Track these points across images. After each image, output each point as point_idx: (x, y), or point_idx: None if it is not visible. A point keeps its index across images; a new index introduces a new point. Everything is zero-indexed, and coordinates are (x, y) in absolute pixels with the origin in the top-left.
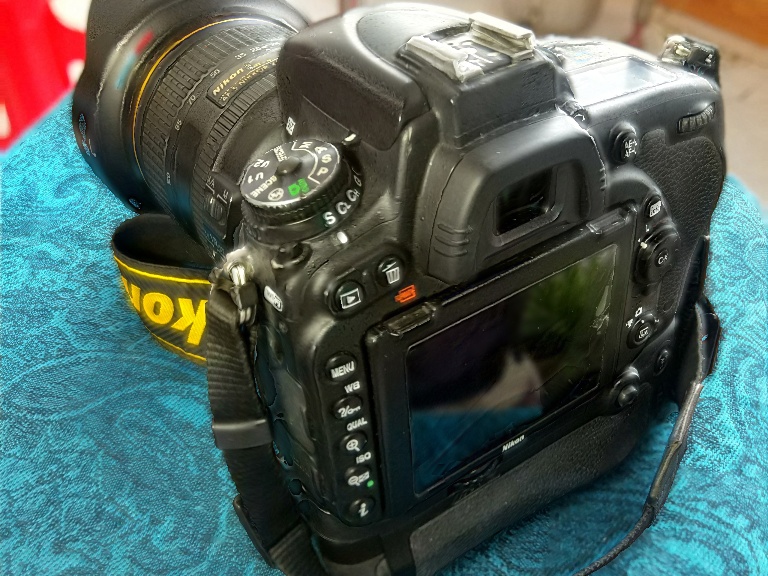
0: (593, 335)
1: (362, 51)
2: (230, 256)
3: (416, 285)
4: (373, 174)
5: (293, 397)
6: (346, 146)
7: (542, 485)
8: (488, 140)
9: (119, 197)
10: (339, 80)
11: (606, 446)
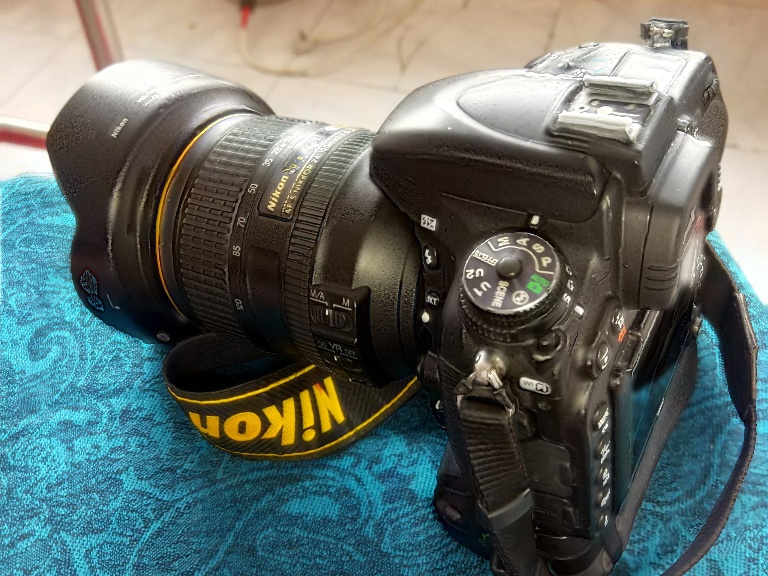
0: (689, 293)
1: (505, 139)
2: (479, 365)
3: (624, 321)
4: (572, 245)
5: (549, 459)
6: (537, 229)
7: (666, 428)
8: (660, 182)
9: (146, 337)
10: (495, 172)
11: (686, 373)
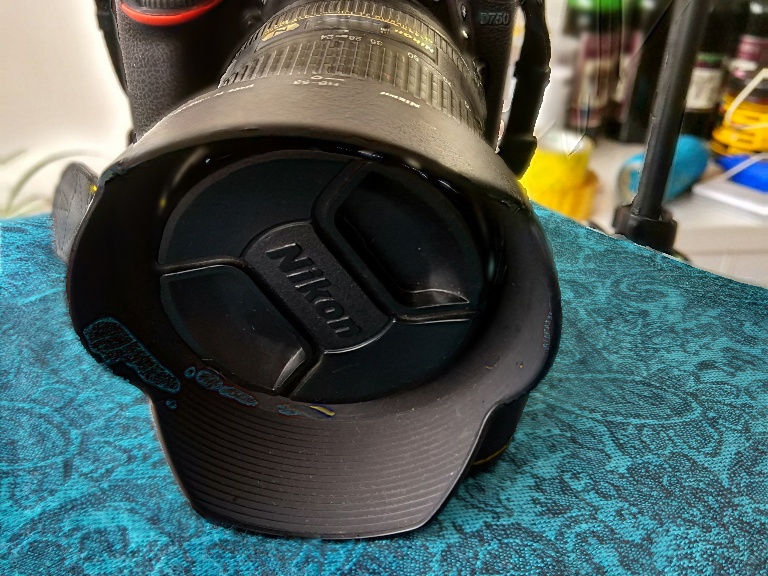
0: None
1: None
2: None
3: None
4: None
5: None
6: None
7: None
8: None
9: None
10: None
11: None
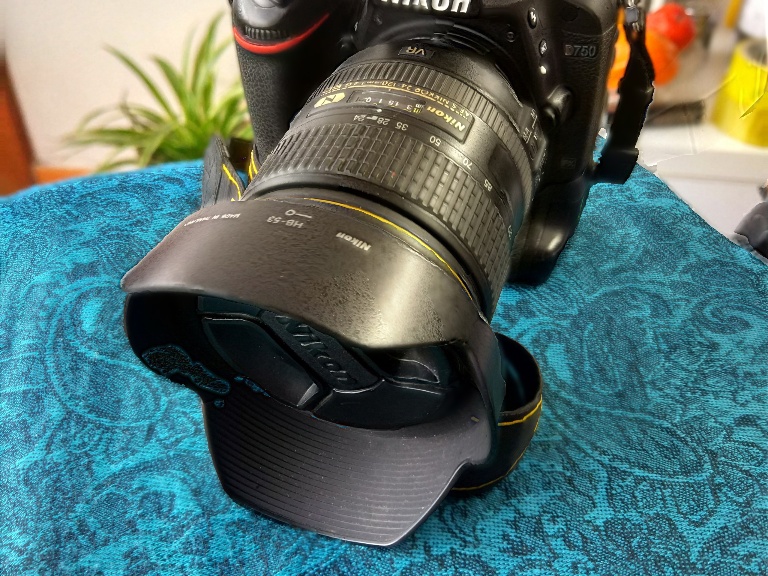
0: None
1: None
2: None
3: None
4: None
5: None
6: None
7: None
8: None
9: None
10: None
11: None
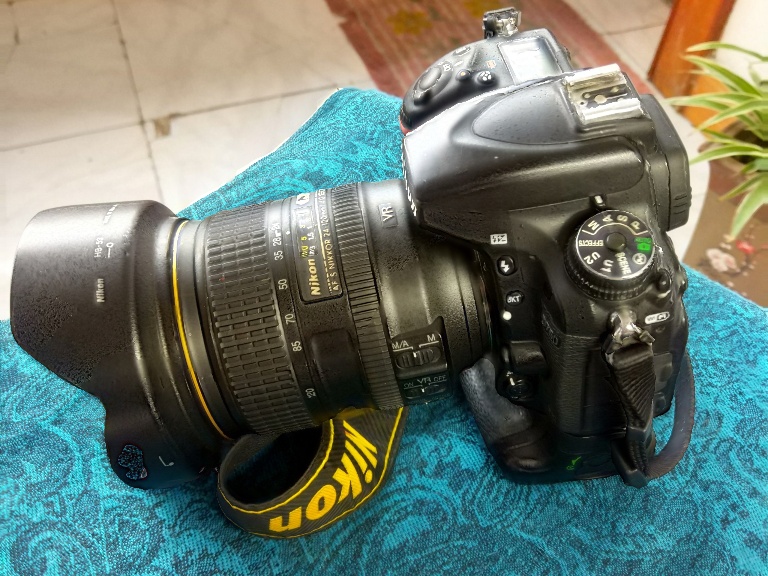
0: None
1: (550, 149)
2: (622, 324)
3: None
4: (628, 206)
5: None
6: None
7: None
8: None
9: None
10: (554, 176)
11: None
